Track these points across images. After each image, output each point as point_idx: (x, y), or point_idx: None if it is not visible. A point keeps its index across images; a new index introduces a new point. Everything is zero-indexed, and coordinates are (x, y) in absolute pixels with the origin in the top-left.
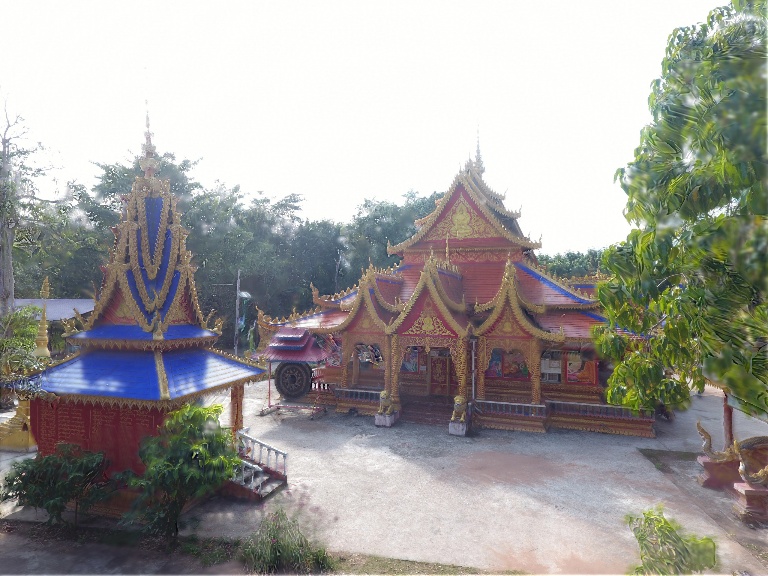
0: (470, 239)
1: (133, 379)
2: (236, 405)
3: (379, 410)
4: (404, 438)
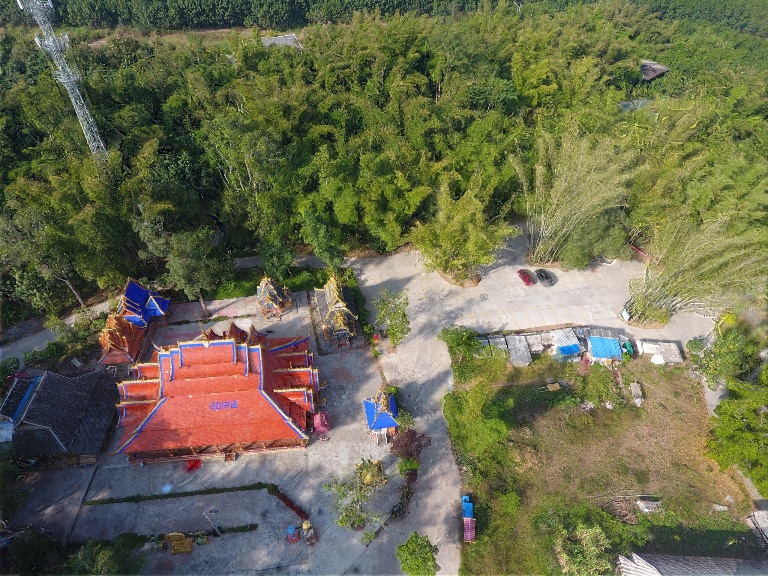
0: (262, 360)
1: (391, 402)
2: (320, 455)
3: (325, 403)
4: (334, 396)
